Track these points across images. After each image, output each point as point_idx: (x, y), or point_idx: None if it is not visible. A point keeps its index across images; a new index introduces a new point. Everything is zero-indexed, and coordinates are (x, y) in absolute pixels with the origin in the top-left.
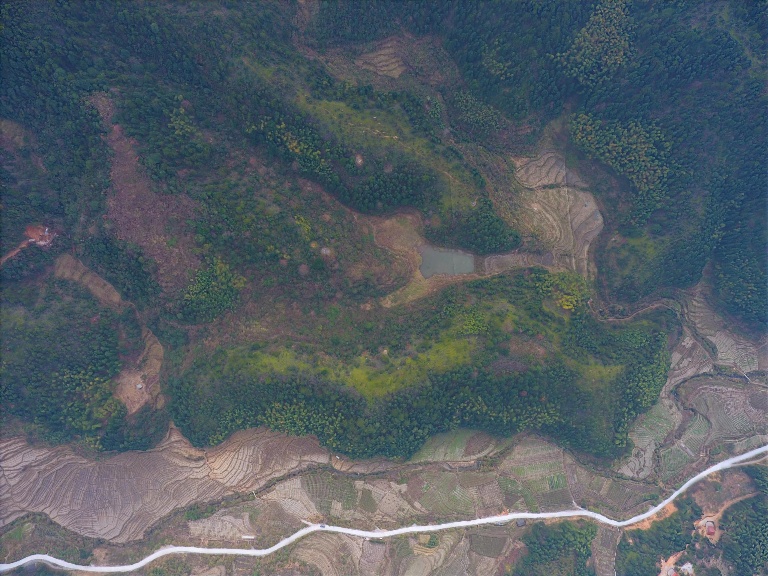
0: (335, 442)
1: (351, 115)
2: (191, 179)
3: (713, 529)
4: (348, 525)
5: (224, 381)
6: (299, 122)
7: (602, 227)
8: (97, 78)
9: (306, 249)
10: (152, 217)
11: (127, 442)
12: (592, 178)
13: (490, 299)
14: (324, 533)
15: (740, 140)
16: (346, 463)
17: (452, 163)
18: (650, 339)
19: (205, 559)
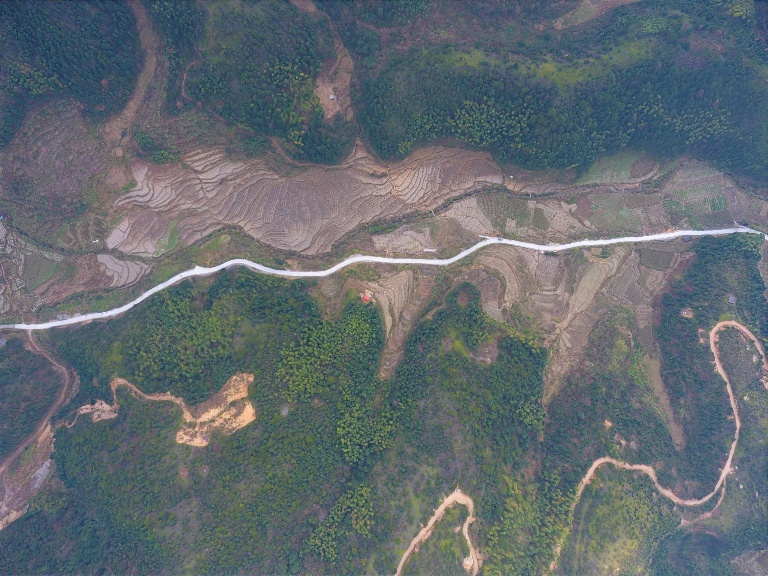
0: (520, 143)
1: None
2: None
3: None
4: (524, 239)
5: (420, 76)
6: None
7: None
8: None
9: None
10: None
11: (324, 145)
12: None
13: (663, 9)
14: (502, 245)
15: None
16: (519, 184)
17: None
18: None
19: (392, 267)
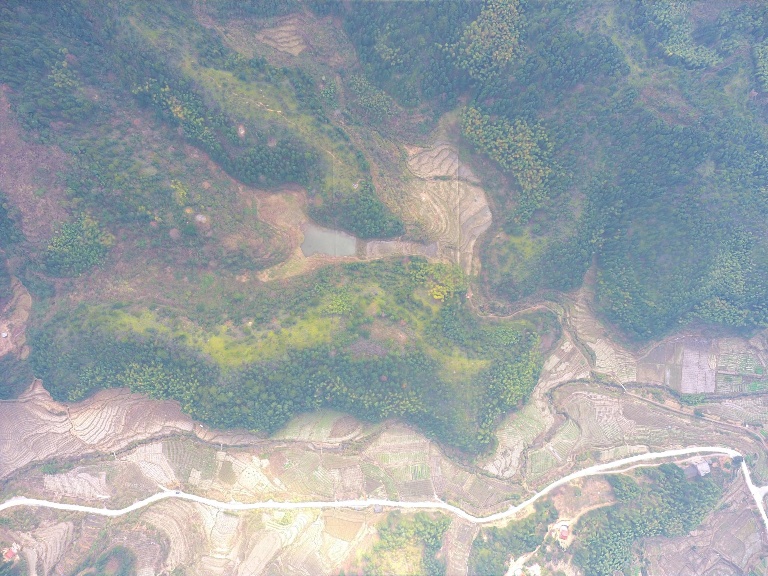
0: (192, 409)
1: (236, 85)
2: (67, 132)
3: (566, 533)
4: (204, 494)
5: (82, 336)
6: (183, 87)
7: (490, 223)
8: None
9: (179, 214)
10: (20, 165)
11: None
12: (483, 173)
13: (362, 282)
14: (179, 500)
15: (617, 146)
16: (210, 433)
17: (337, 143)
18: (520, 338)
19: (55, 514)
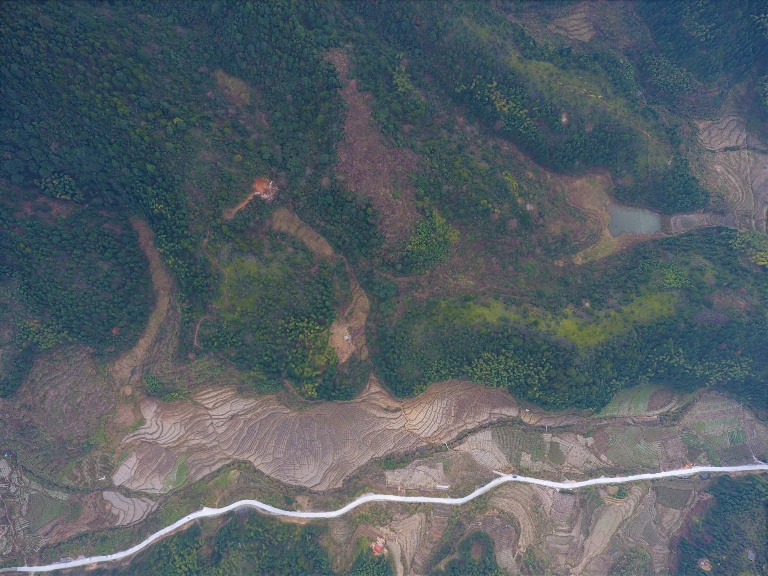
0: (538, 392)
1: (560, 74)
2: (411, 134)
3: None
4: (539, 476)
5: (438, 331)
6: (510, 81)
7: None
8: (333, 35)
9: (514, 204)
10: (381, 170)
11: (338, 390)
12: None
13: (686, 255)
14: (517, 483)
15: None
16: (534, 416)
17: (650, 123)
18: None
19: (404, 507)
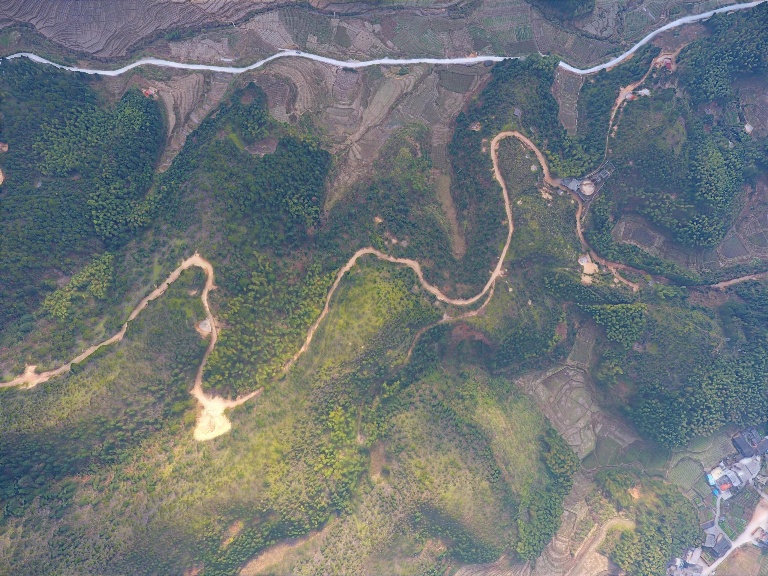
0: None
1: None
2: None
3: (670, 62)
4: (323, 53)
5: None
6: None
7: None
8: None
9: None
10: None
11: None
12: None
13: None
14: (300, 58)
15: None
16: (322, 1)
17: None
18: None
19: (184, 71)
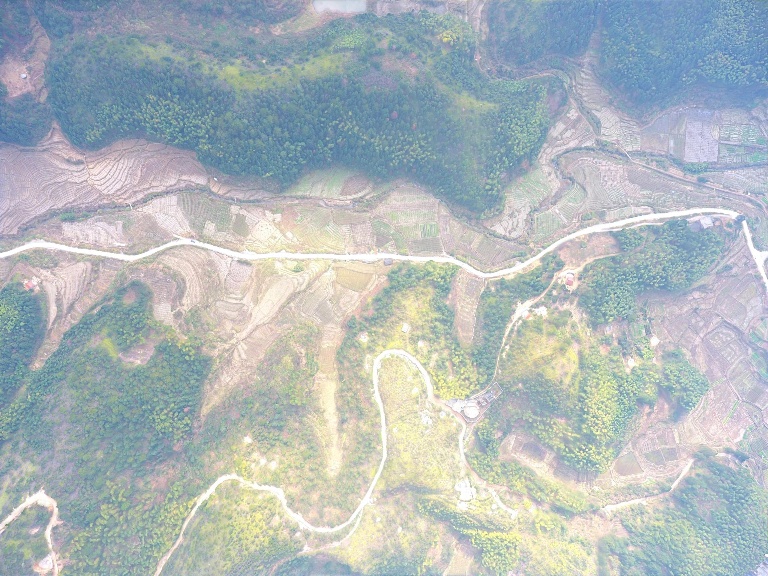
0: (207, 145)
1: None
2: None
3: (572, 279)
4: (218, 243)
5: (101, 64)
6: None
7: None
8: None
9: None
10: None
11: (4, 123)
12: None
13: (373, 26)
14: (194, 247)
15: None
16: (224, 187)
17: None
18: (528, 87)
19: (74, 256)
